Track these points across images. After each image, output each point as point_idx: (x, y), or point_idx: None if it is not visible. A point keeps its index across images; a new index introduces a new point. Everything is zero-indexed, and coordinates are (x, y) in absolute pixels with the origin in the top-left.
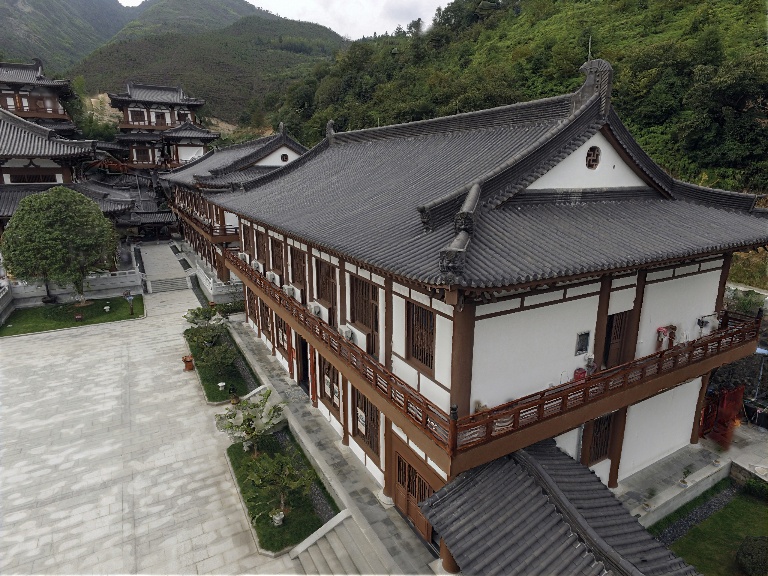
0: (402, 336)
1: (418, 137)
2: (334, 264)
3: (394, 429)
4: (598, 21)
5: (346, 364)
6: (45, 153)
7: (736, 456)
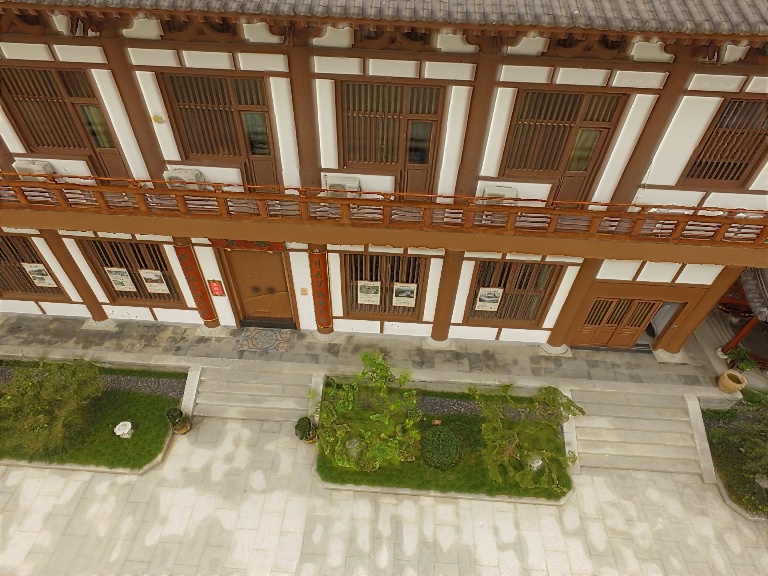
0: (683, 156)
1: None
2: (444, 79)
3: (602, 277)
4: None
5: (582, 238)
6: None
7: None
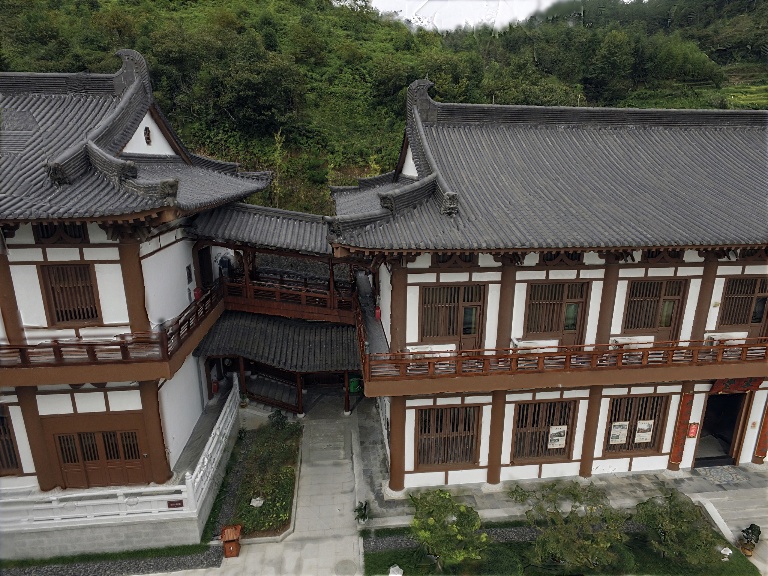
0: None
1: (672, 127)
2: None
3: None
4: (283, 7)
5: None
6: None
7: None
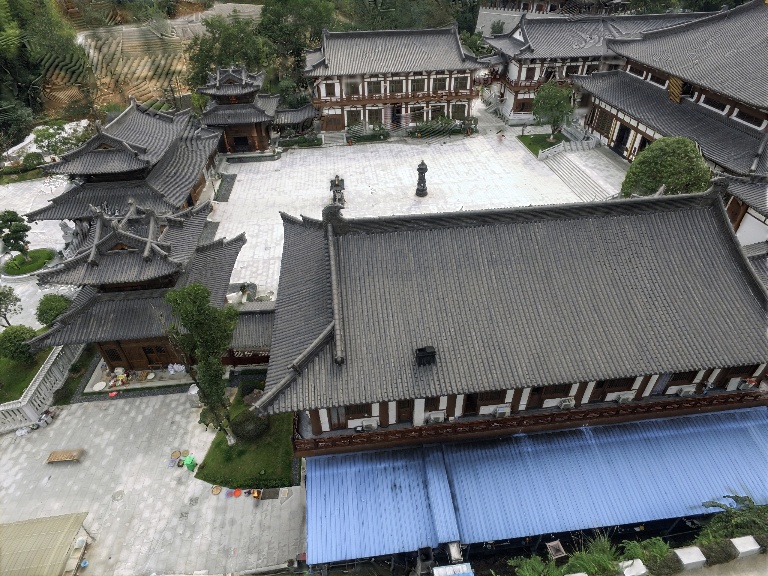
0: None
1: None
2: None
3: None
4: None
5: None
6: (753, 100)
7: (301, 493)
